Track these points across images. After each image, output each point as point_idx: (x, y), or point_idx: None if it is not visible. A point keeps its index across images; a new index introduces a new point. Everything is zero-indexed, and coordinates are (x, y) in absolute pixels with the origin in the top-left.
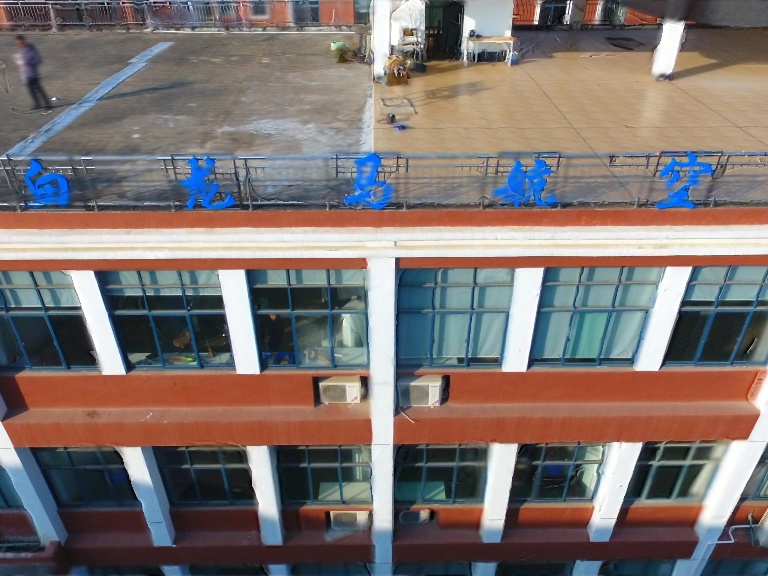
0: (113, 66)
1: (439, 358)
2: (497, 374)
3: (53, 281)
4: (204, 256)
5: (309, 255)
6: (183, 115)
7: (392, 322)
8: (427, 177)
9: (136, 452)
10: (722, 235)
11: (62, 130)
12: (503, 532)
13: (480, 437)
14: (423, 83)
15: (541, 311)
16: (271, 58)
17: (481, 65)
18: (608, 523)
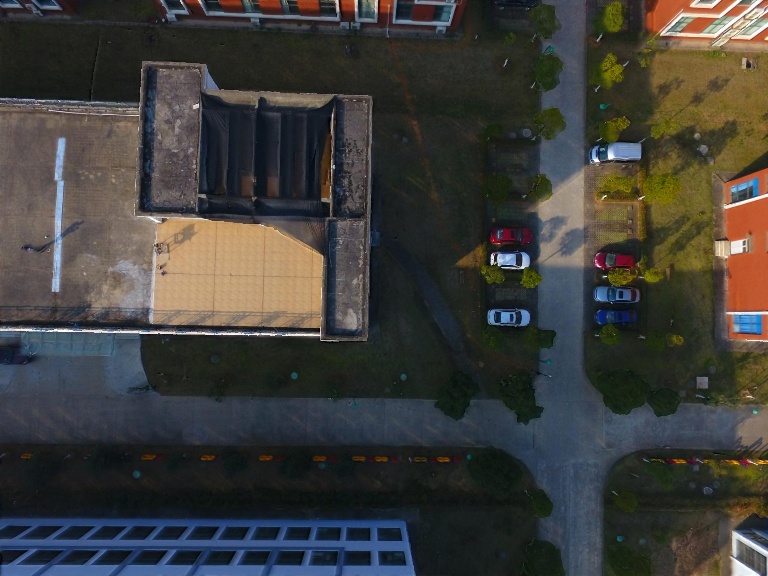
0: (51, 188)
1: None
2: None
3: None
4: None
5: None
6: (94, 255)
7: None
8: (166, 310)
9: None
10: None
11: (60, 268)
12: None
13: None
14: (175, 224)
15: None
16: (115, 176)
17: None
18: None
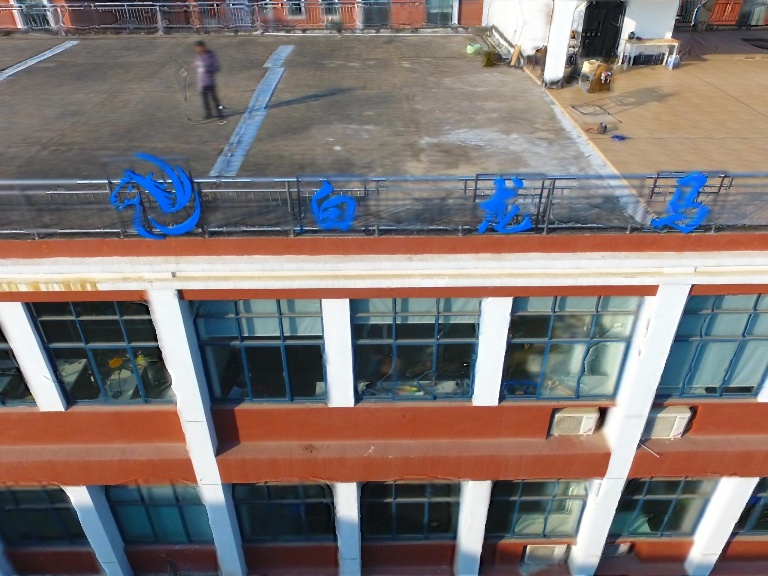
0: (253, 71)
1: (688, 387)
2: (751, 405)
3: (295, 309)
4: (487, 284)
5: (603, 282)
6: (370, 125)
7: (666, 352)
8: None
9: (350, 488)
10: None
11: (253, 142)
12: None
13: (721, 471)
14: None
15: None
16: (410, 62)
17: (640, 69)
18: None
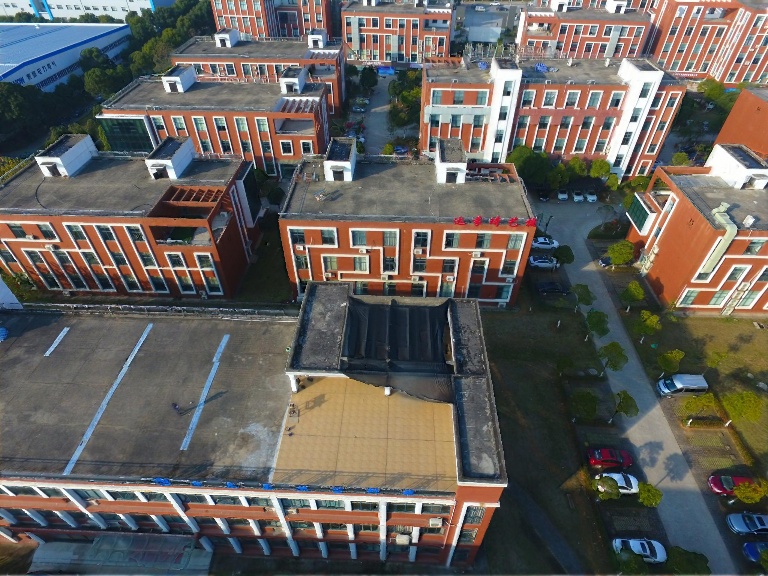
0: (208, 367)
1: (295, 505)
2: None
3: None
4: (232, 495)
5: None
6: (230, 418)
7: (279, 504)
8: (288, 469)
9: None
10: (350, 498)
11: (195, 428)
12: (324, 535)
13: None
14: (308, 394)
15: (317, 501)
16: (263, 359)
17: None
18: (352, 537)
